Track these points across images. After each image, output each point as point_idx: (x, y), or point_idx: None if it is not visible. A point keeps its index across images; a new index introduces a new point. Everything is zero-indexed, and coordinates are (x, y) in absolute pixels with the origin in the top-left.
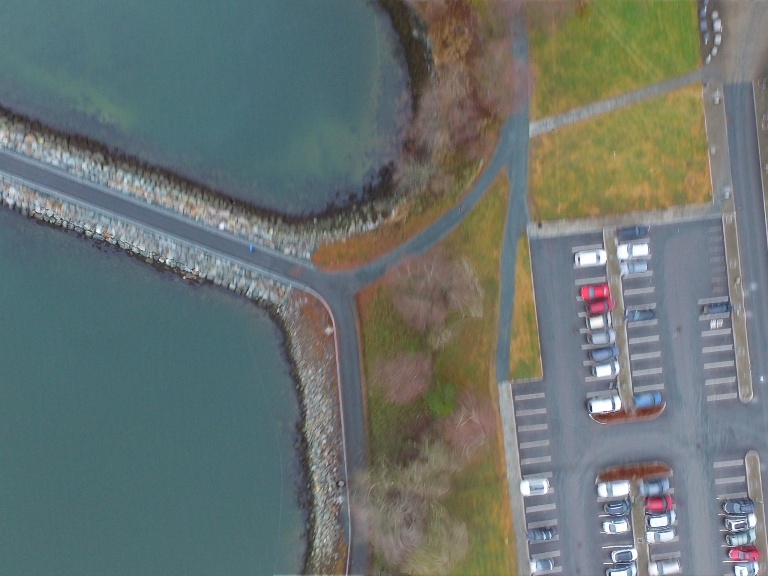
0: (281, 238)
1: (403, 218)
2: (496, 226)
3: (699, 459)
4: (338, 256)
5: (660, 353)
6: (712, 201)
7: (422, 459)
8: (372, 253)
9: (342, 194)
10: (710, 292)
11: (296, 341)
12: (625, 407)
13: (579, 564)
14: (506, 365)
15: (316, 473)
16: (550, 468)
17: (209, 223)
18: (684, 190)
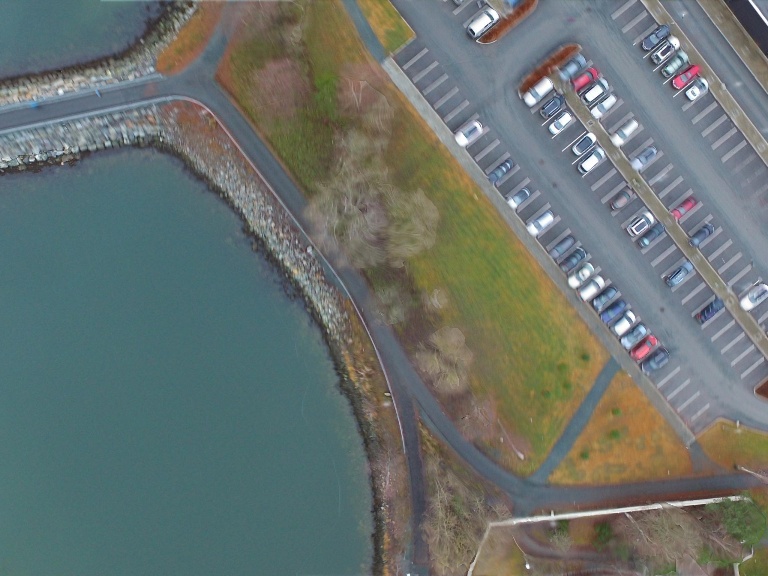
0: (120, 72)
1: None
2: None
3: (596, 21)
4: (178, 53)
5: None
6: None
7: (346, 155)
8: (205, 31)
9: (152, 5)
10: None
11: (193, 155)
12: (503, 15)
13: (552, 179)
14: (377, 44)
15: (285, 259)
16: (473, 110)
17: (48, 96)
18: None
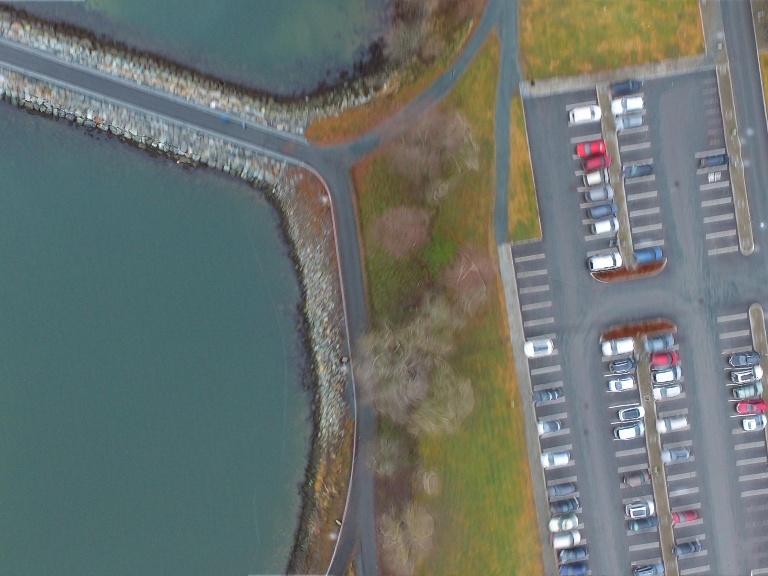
0: (273, 116)
1: (395, 89)
2: (489, 87)
3: (703, 314)
4: (331, 130)
5: (659, 209)
6: (705, 53)
7: (424, 315)
8: (365, 125)
9: (333, 72)
10: (707, 145)
11: (293, 220)
12: (626, 264)
13: (586, 425)
14: (505, 227)
15: (319, 353)
16: (553, 329)
17: (200, 102)
18: (676, 43)
